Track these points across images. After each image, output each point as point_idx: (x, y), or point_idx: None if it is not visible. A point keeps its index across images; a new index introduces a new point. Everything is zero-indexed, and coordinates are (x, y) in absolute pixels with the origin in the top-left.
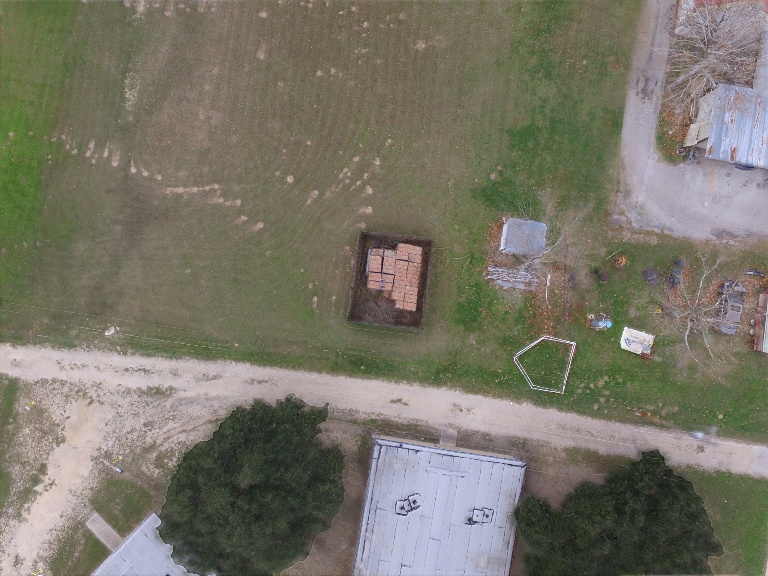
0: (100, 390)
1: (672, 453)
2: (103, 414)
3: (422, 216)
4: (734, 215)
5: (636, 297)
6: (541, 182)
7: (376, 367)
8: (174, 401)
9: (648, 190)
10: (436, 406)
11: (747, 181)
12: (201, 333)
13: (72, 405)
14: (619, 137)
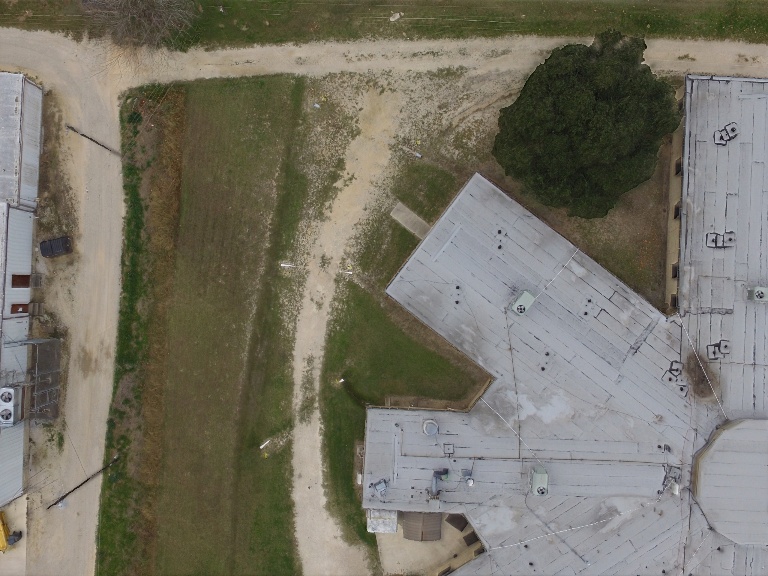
0: (391, 78)
1: None
2: (396, 101)
3: None
4: None
5: None
6: None
7: (661, 24)
8: (466, 80)
9: None
10: (722, 58)
11: None
12: (486, 9)
13: (364, 96)
14: None
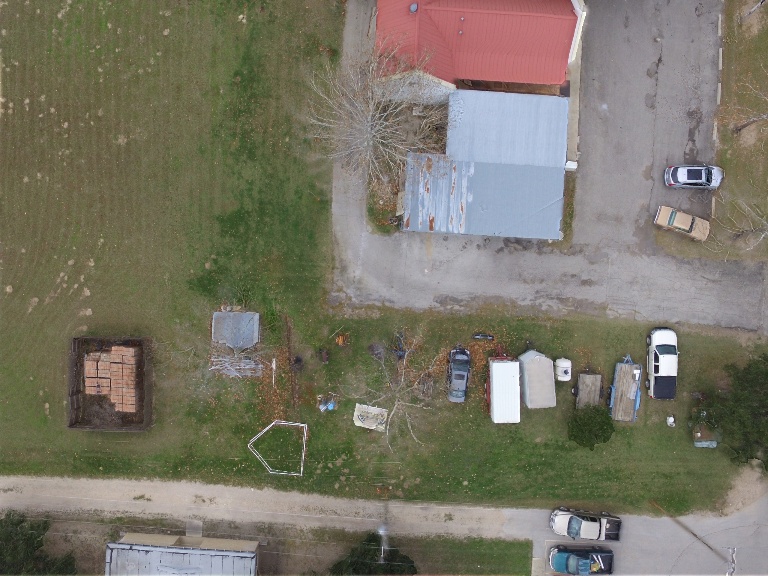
0: None
1: (419, 523)
2: None
3: (142, 313)
4: (456, 279)
5: (365, 372)
6: (257, 266)
7: (114, 467)
8: None
9: (365, 263)
10: (178, 499)
11: (466, 243)
12: None
13: None
14: (329, 212)
